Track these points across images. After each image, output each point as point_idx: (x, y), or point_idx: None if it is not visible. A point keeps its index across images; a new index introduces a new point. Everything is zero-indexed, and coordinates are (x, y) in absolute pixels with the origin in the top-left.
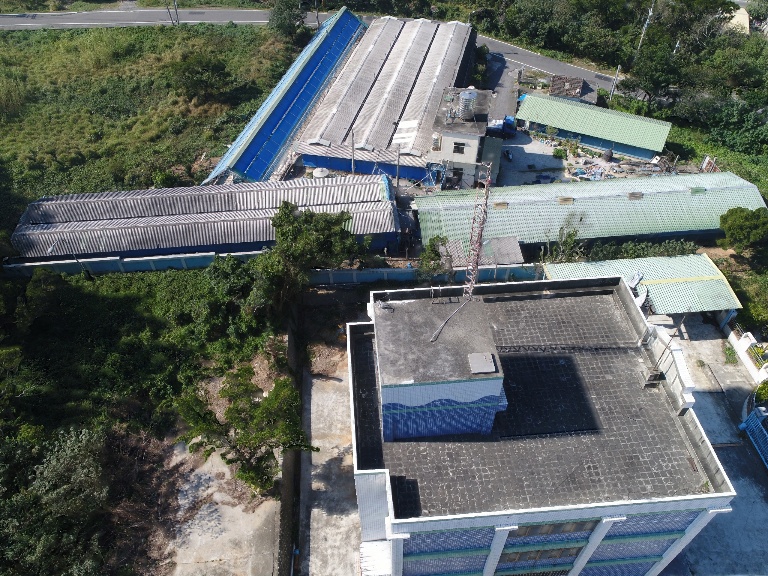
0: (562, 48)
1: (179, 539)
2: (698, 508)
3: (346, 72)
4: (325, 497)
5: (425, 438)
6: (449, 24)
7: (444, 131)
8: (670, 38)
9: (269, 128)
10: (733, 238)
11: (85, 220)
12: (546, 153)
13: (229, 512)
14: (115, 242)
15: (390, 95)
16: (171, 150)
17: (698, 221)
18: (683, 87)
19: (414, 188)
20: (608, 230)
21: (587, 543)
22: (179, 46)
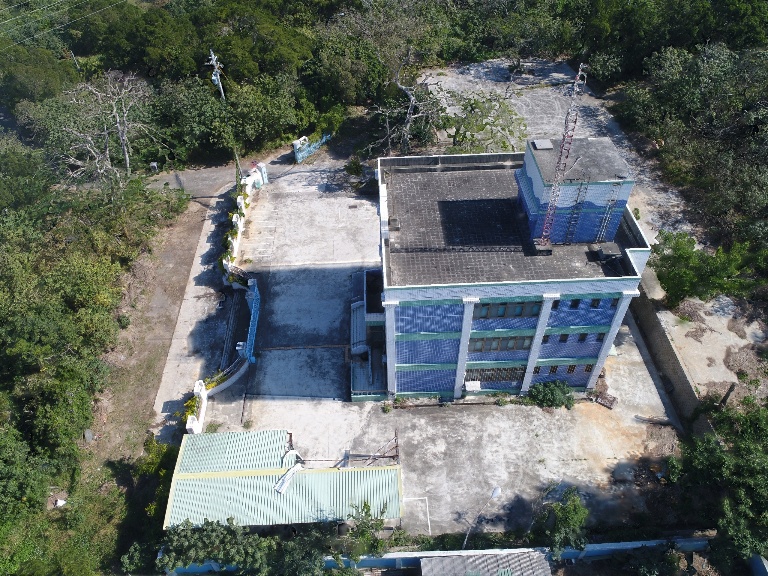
0: None
1: None
2: None
3: None
4: None
5: None
6: None
7: None
8: None
9: None
10: None
11: None
12: None
13: None
14: None
15: None
16: None
17: None
18: None
19: None
20: None
21: None
22: None
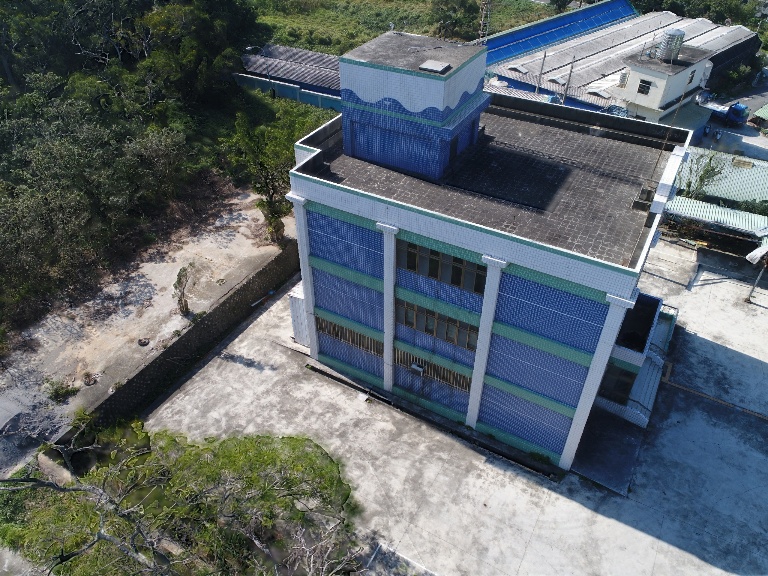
0: None
1: (197, 238)
2: (598, 294)
3: (588, 36)
4: None
5: (379, 163)
6: (731, 27)
7: (633, 64)
8: None
9: None
10: None
11: (295, 62)
12: (767, 148)
13: (242, 240)
14: (303, 76)
15: (616, 56)
16: None
17: None
18: None
19: None
20: None
21: (480, 320)
22: None
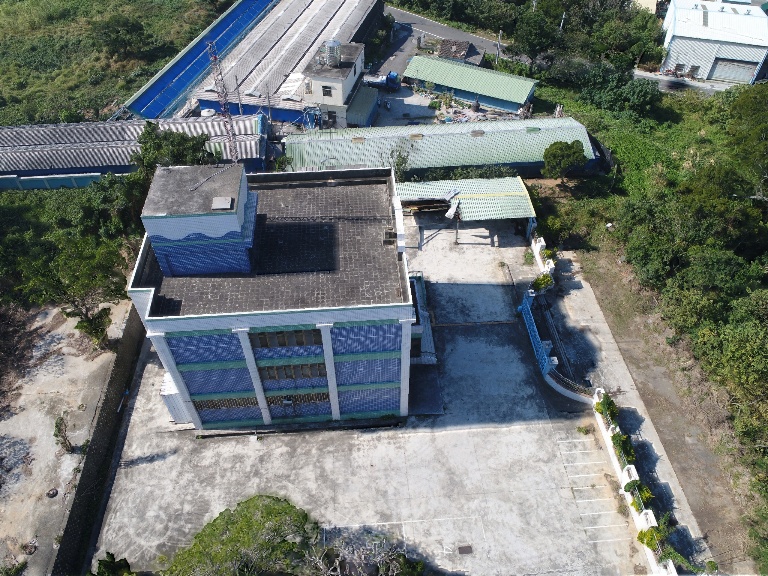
0: (468, 20)
1: (27, 378)
2: (393, 321)
3: (253, 33)
4: None
5: (198, 275)
6: None
7: (312, 75)
8: (565, 12)
9: (170, 77)
10: (550, 166)
11: None
12: (423, 104)
13: (72, 360)
14: (14, 163)
15: (287, 52)
16: (85, 96)
17: (528, 155)
18: (556, 50)
19: (295, 130)
20: (449, 161)
21: (324, 358)
22: (108, 10)
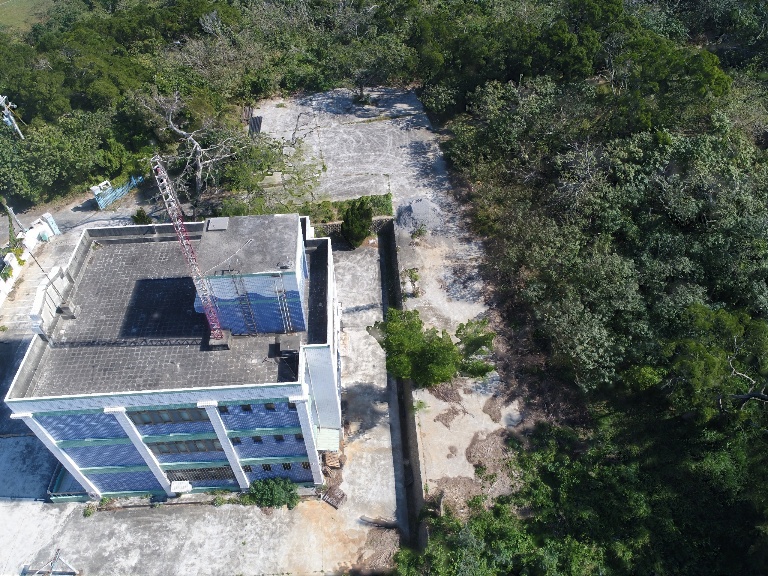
0: None
1: None
2: None
3: None
4: (376, 396)
5: None
6: None
7: None
8: None
9: None
10: None
11: None
12: None
13: None
14: None
15: None
16: None
17: None
18: None
19: None
20: None
21: None
22: None
